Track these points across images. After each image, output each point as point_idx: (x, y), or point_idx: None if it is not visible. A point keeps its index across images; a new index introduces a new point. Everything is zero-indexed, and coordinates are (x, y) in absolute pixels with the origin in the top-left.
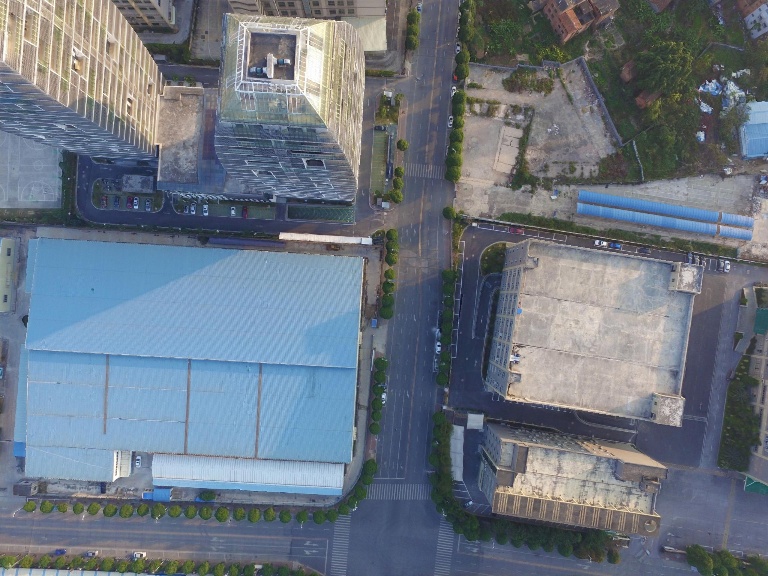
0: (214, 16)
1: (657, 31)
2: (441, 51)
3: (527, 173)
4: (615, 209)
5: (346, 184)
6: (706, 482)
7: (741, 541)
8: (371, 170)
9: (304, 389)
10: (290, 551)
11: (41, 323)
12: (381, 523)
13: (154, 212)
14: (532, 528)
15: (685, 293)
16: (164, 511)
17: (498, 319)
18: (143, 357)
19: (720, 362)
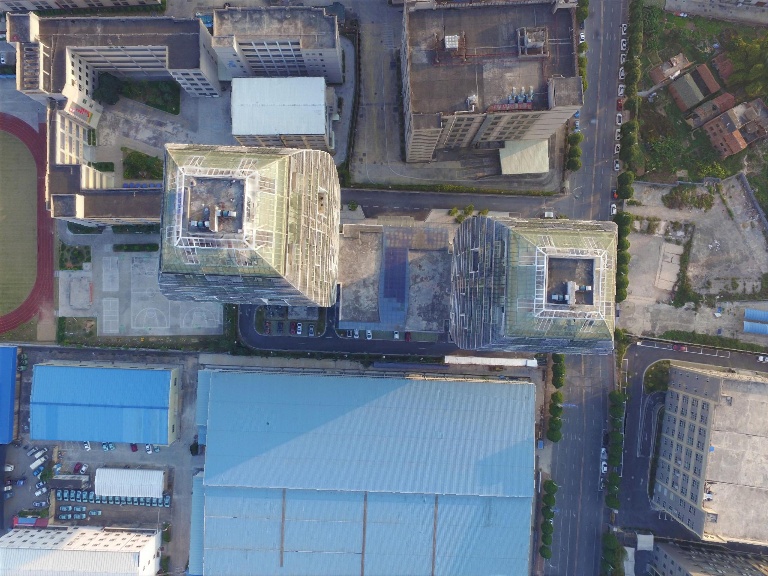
0: (371, 138)
1: None
2: (599, 168)
3: (691, 291)
4: None
5: None
6: None
7: None
8: None
9: (480, 518)
10: None
11: (218, 459)
12: None
13: (317, 337)
14: None
15: None
16: None
17: (667, 440)
18: (320, 490)
19: None
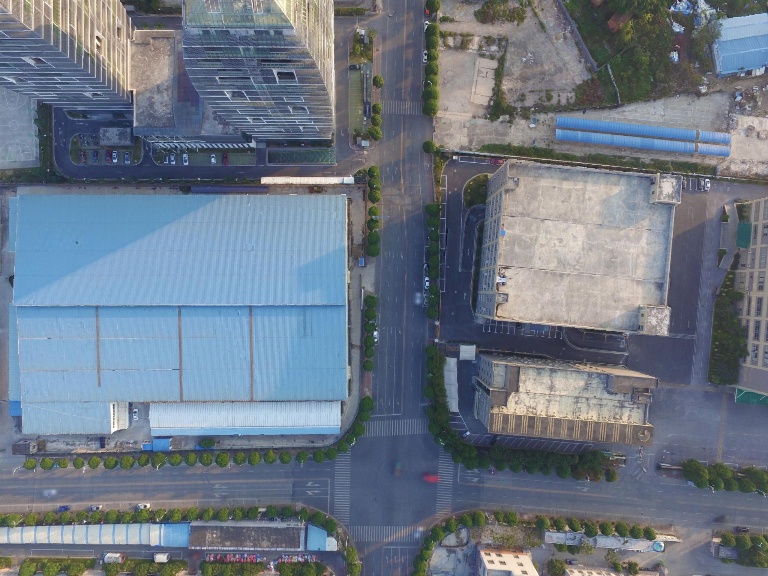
0: None
1: None
2: None
3: (504, 103)
4: (593, 133)
5: (321, 105)
6: (698, 398)
7: (735, 454)
8: (349, 110)
9: (295, 329)
10: (292, 493)
11: (27, 279)
12: (381, 459)
13: (134, 165)
14: (529, 452)
15: (665, 204)
16: (164, 460)
17: (484, 249)
18: (132, 307)
19: (705, 280)
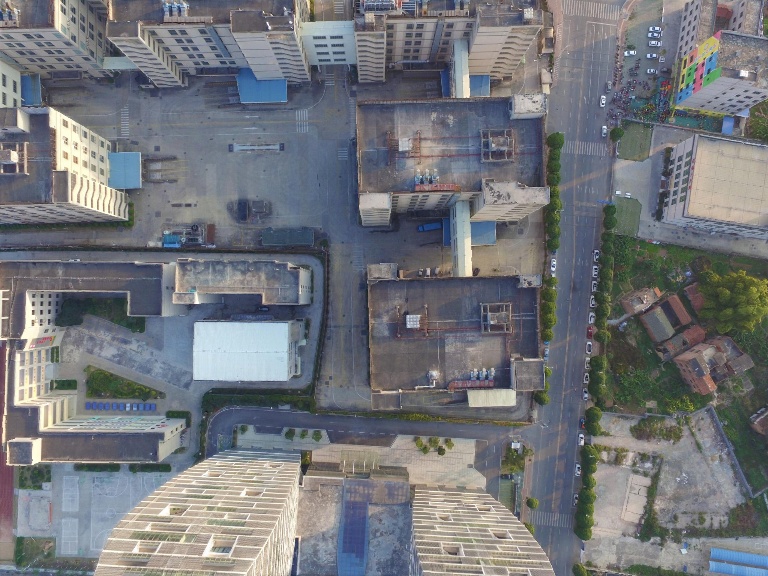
0: (338, 361)
1: None
2: (568, 396)
3: (657, 527)
4: (748, 568)
5: None
6: None
7: None
8: None
9: None
10: None
11: None
12: None
13: None
14: None
15: None
16: None
17: None
18: None
19: None
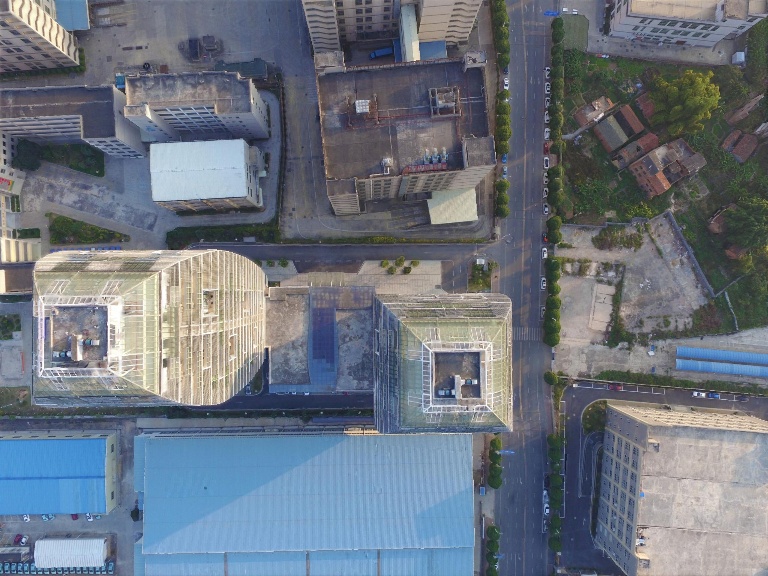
0: (300, 192)
1: (742, 181)
2: (529, 212)
3: (624, 331)
4: (713, 363)
5: None
6: None
7: None
8: None
9: (423, 570)
10: None
11: (156, 527)
12: None
13: (254, 395)
14: None
15: None
16: None
17: (606, 480)
18: (261, 552)
19: None
